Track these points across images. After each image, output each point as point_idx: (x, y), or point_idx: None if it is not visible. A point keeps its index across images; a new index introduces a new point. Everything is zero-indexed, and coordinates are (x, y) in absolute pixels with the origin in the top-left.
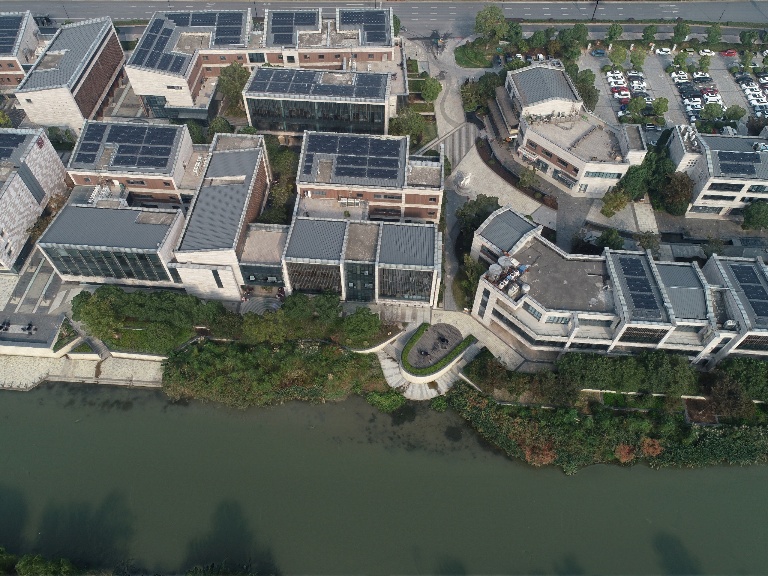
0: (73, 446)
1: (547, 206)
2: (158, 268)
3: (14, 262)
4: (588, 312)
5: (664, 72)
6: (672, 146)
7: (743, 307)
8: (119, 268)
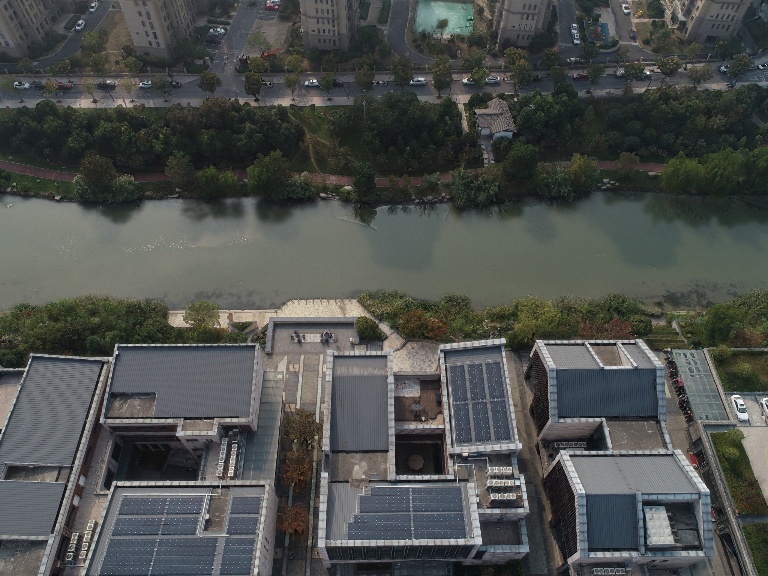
0: (239, 265)
1: None
2: None
3: None
4: None
5: None
6: None
7: None
8: None
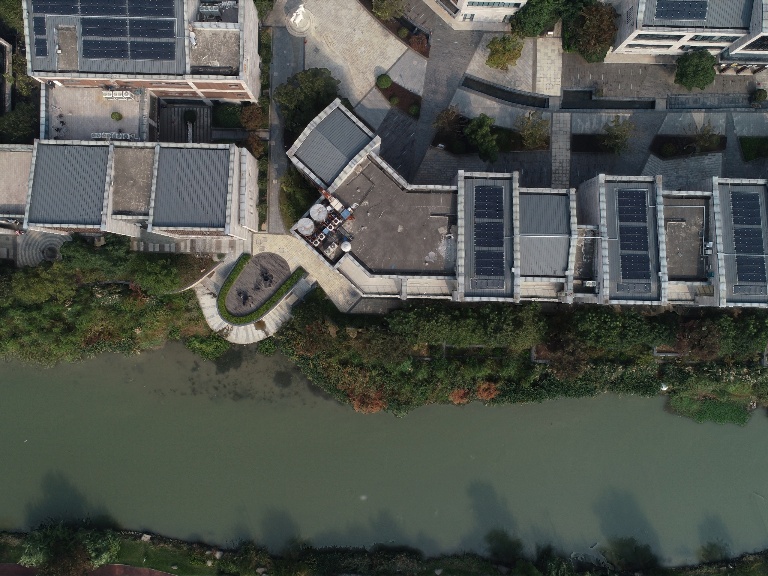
0: None
1: (415, 50)
2: None
3: None
4: (420, 276)
5: None
6: None
7: (609, 267)
8: None
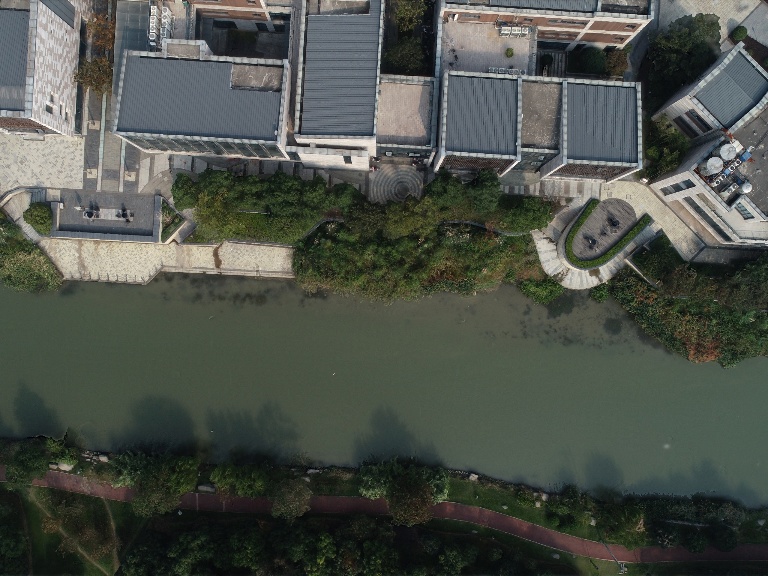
0: (216, 345)
1: None
2: (273, 151)
3: (74, 125)
4: None
5: None
6: None
7: None
8: (221, 149)
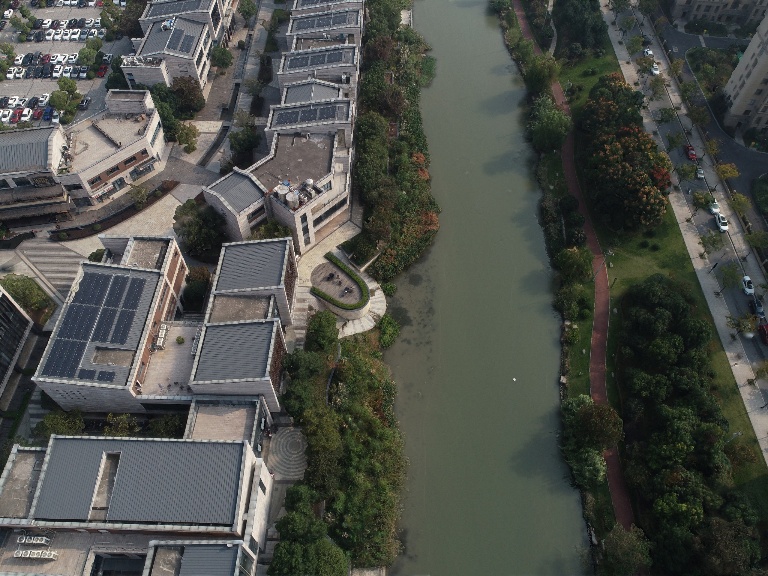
0: None
1: (173, 189)
2: (246, 566)
3: None
4: (334, 148)
5: (1, 82)
6: (139, 80)
7: None
8: None
